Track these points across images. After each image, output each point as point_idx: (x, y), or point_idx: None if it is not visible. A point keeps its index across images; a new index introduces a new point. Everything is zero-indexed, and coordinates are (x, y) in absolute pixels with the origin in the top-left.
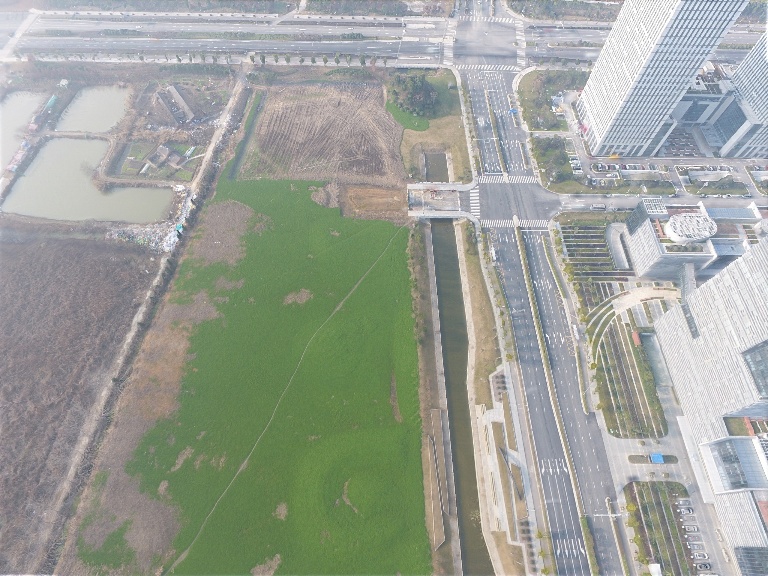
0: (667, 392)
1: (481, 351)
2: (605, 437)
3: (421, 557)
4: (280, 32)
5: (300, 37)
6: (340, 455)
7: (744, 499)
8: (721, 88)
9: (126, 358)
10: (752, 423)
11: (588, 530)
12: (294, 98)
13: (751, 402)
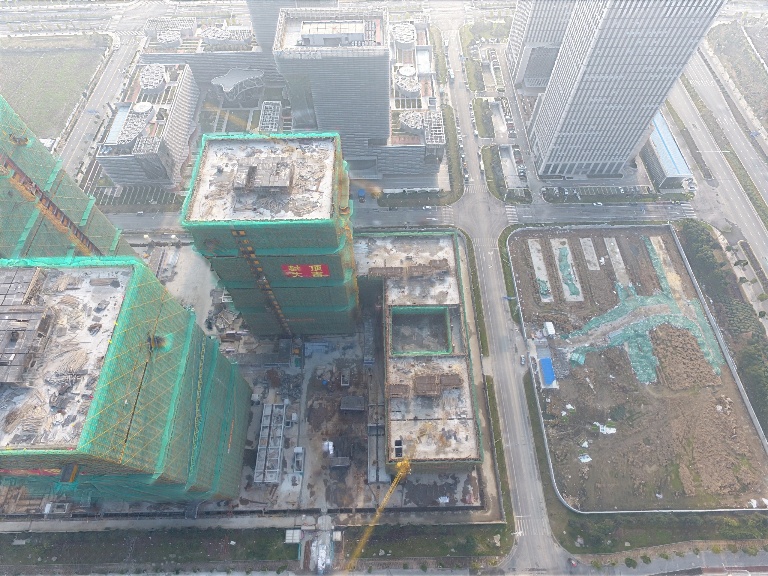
0: None
1: None
2: None
3: None
4: None
5: None
6: None
7: None
8: None
9: None
10: None
11: None
12: None
13: None
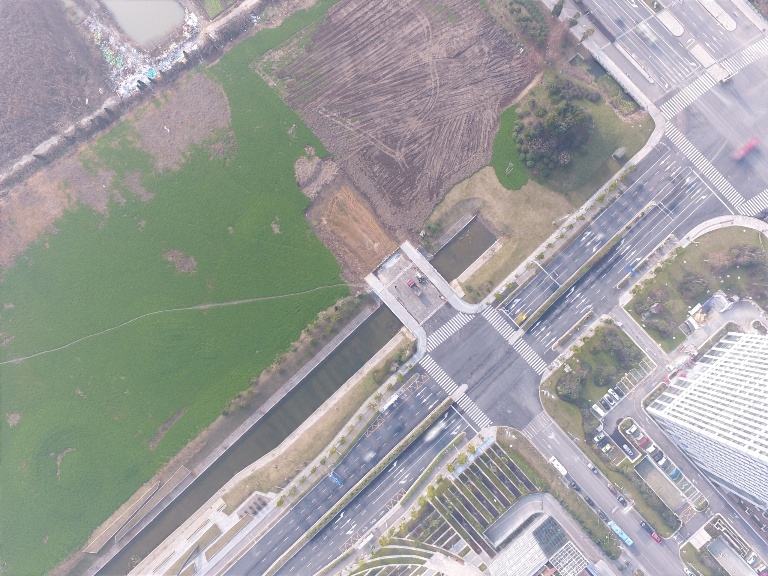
0: None
1: (274, 466)
2: None
3: (69, 545)
4: None
5: None
6: (83, 427)
7: None
8: None
9: (8, 179)
10: None
11: None
12: None
13: None
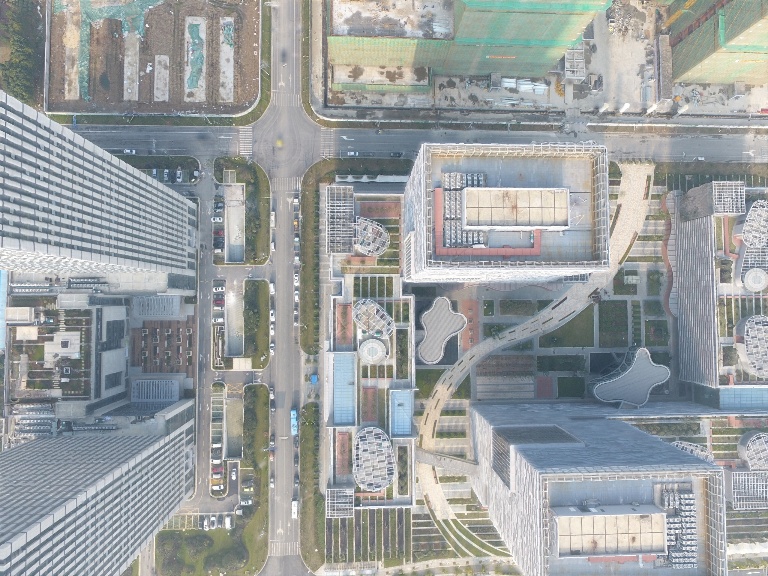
0: None
1: None
2: None
3: None
4: None
5: None
6: None
7: None
8: (78, 310)
9: None
10: None
11: None
12: None
13: None
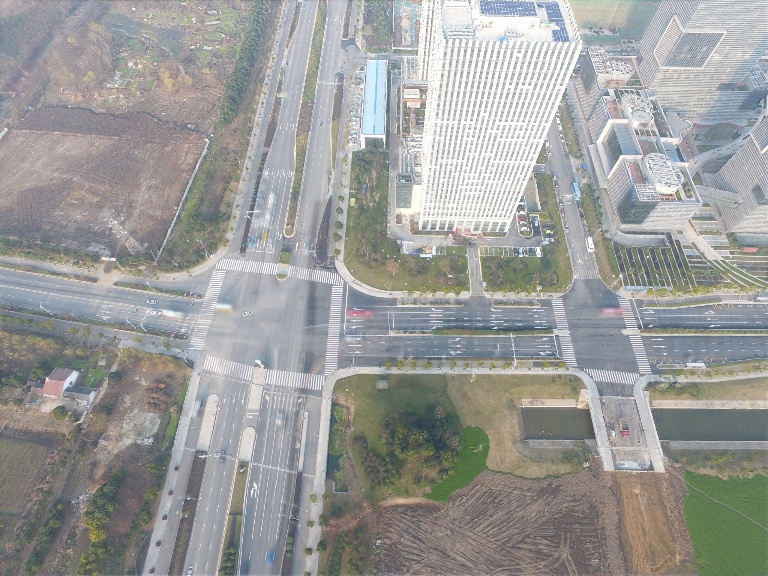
0: None
1: None
2: None
3: None
4: None
5: None
6: None
7: None
8: None
9: None
10: None
11: None
12: None
13: None
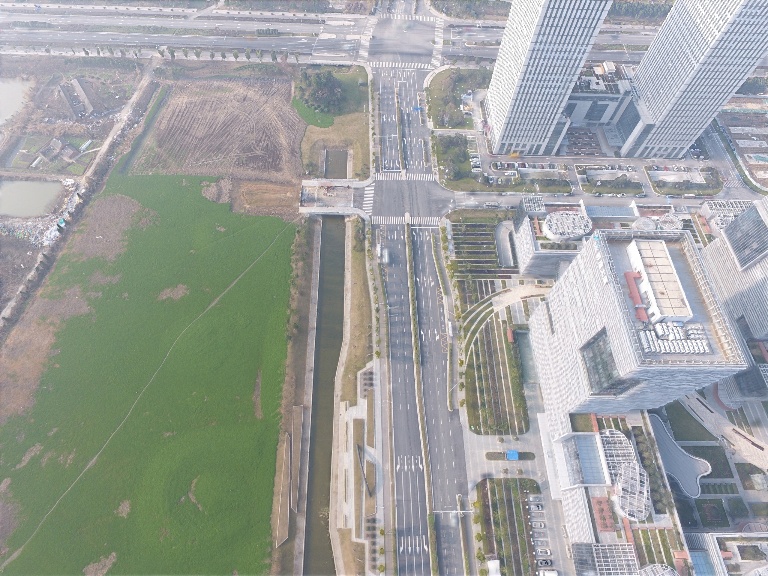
0: (534, 389)
1: (353, 348)
2: (465, 434)
3: (260, 555)
4: (196, 27)
5: (215, 32)
6: (192, 452)
7: (579, 495)
8: (619, 88)
9: None
10: (598, 419)
11: (432, 527)
12: (200, 93)
13: (584, 398)
